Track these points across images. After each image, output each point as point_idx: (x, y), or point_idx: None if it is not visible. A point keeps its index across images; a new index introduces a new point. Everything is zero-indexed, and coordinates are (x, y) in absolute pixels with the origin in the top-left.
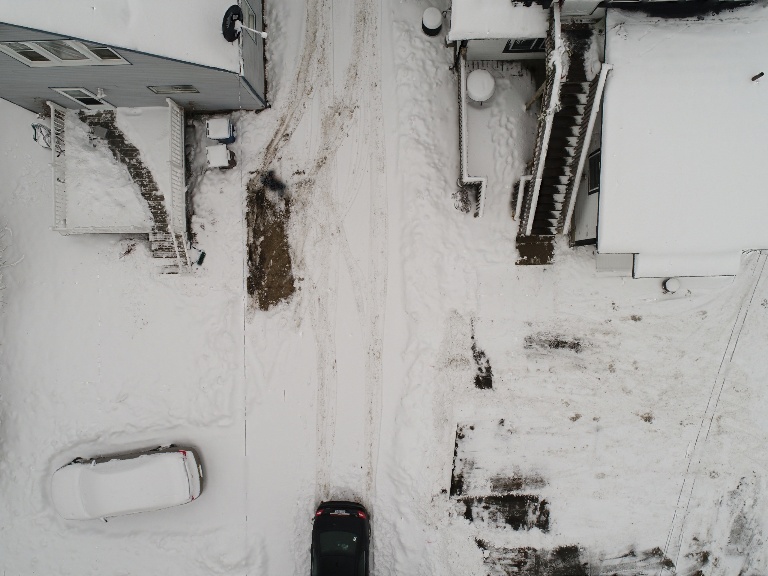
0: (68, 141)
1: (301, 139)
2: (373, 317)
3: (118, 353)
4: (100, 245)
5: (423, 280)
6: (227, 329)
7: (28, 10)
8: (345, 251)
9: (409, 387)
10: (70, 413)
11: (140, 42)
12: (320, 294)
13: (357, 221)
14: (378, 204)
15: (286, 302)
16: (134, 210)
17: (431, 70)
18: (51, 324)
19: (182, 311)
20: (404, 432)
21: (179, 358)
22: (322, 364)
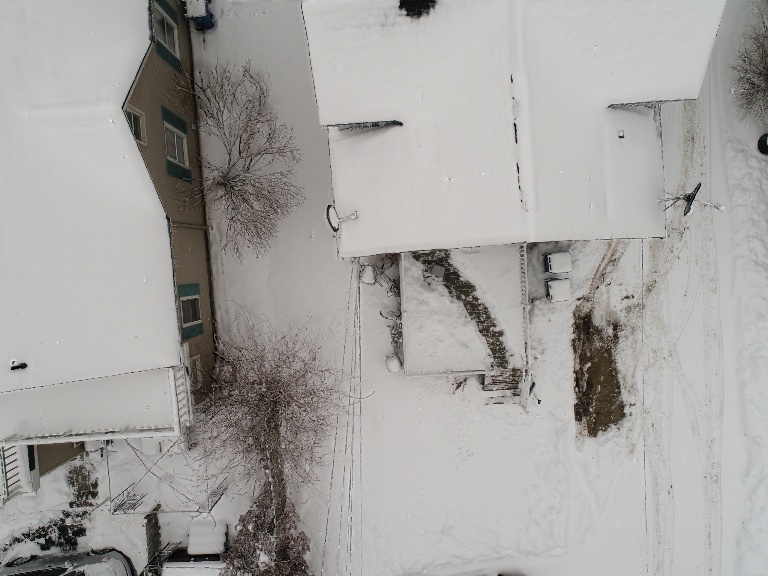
0: (408, 283)
1: (630, 263)
2: (709, 441)
3: (441, 485)
4: (423, 378)
5: (766, 403)
6: (559, 459)
7: (557, 225)
8: (678, 375)
9: (753, 511)
10: (393, 546)
11: (615, 230)
12: (653, 419)
13: (690, 344)
14: (710, 326)
15: (616, 428)
16: (475, 348)
17: (767, 189)
18: (370, 458)
19: (509, 441)
20: (750, 557)
21: (505, 488)
22: (657, 490)
